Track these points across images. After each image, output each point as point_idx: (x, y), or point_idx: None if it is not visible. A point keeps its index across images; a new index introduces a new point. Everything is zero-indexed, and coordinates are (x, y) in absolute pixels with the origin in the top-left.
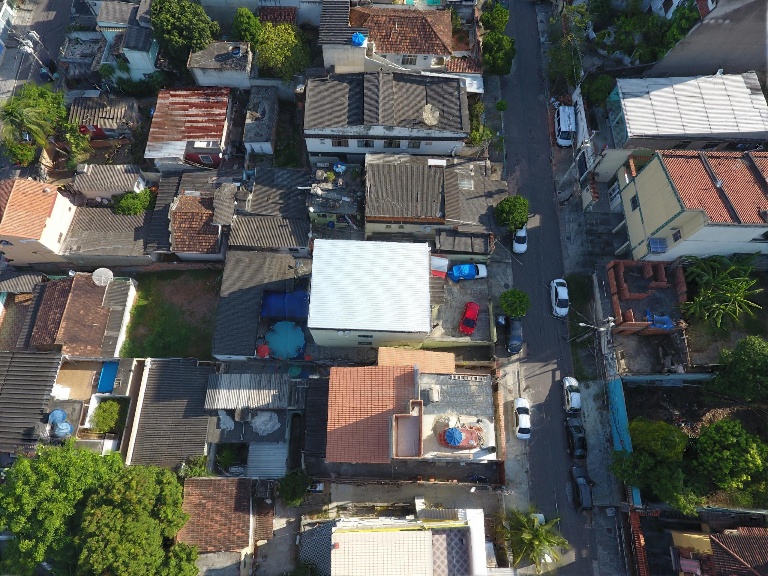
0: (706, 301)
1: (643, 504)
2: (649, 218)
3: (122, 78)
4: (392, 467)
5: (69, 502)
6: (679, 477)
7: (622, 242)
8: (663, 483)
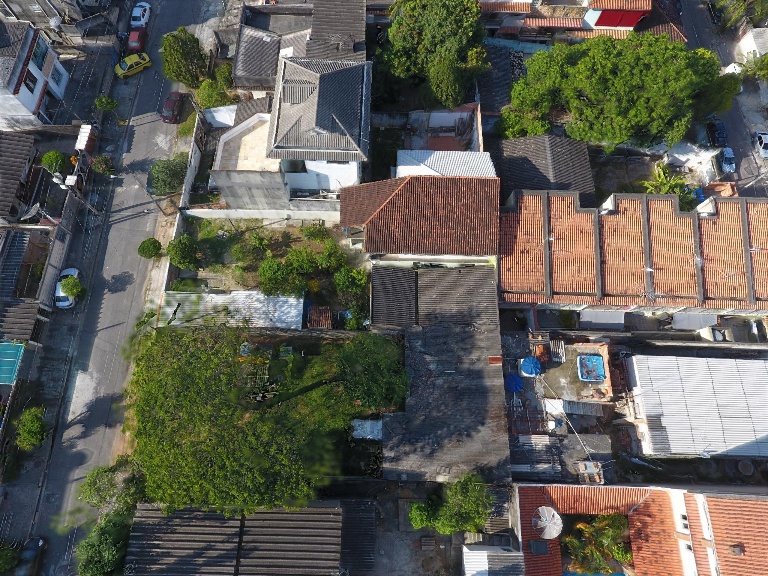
0: None
1: None
2: None
3: None
4: None
5: None
6: None
7: None
8: None
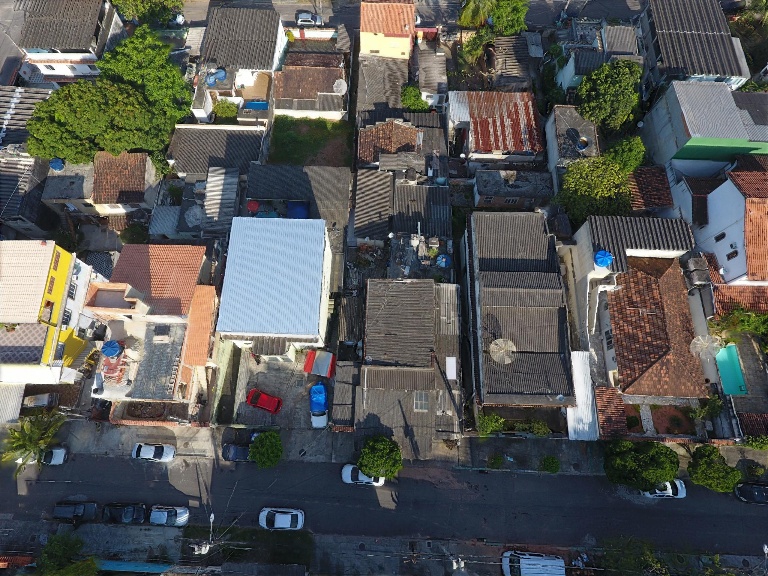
0: None
1: (26, 567)
2: None
3: None
4: None
5: None
6: None
7: None
8: None
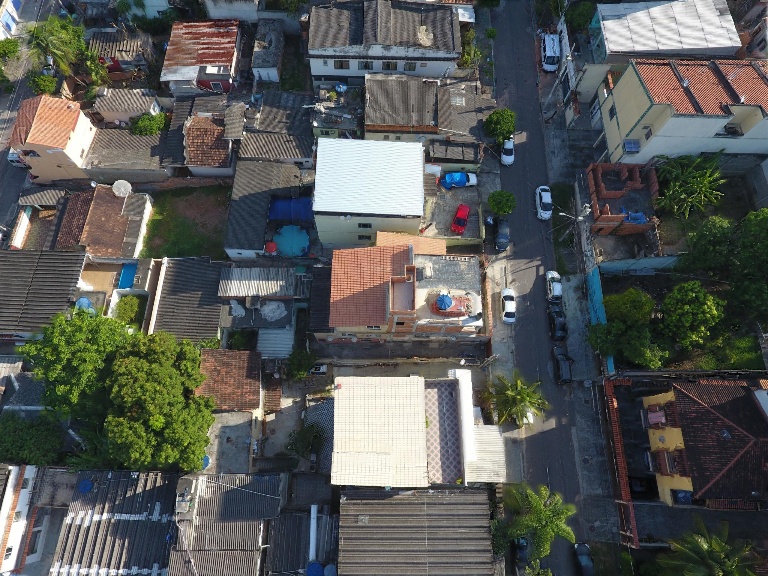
0: (675, 194)
1: (616, 369)
2: (624, 122)
3: (137, 15)
4: (389, 350)
5: (100, 354)
6: (646, 335)
7: (602, 154)
8: (632, 344)
